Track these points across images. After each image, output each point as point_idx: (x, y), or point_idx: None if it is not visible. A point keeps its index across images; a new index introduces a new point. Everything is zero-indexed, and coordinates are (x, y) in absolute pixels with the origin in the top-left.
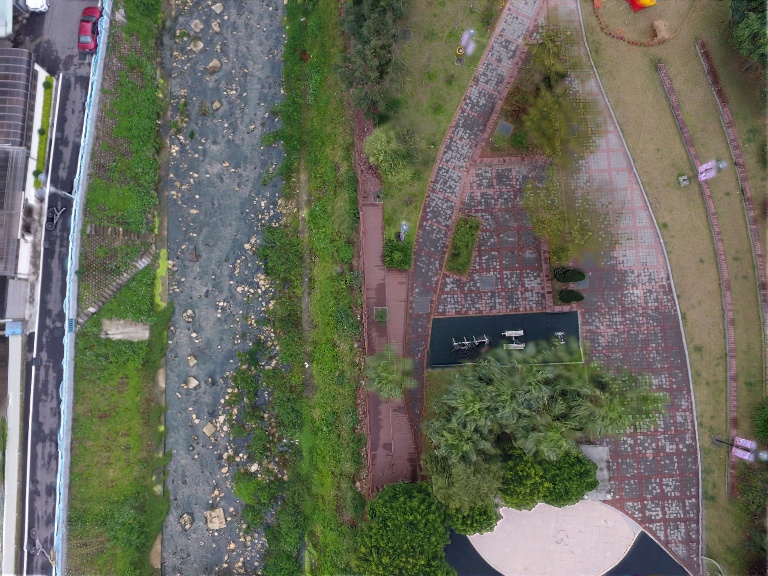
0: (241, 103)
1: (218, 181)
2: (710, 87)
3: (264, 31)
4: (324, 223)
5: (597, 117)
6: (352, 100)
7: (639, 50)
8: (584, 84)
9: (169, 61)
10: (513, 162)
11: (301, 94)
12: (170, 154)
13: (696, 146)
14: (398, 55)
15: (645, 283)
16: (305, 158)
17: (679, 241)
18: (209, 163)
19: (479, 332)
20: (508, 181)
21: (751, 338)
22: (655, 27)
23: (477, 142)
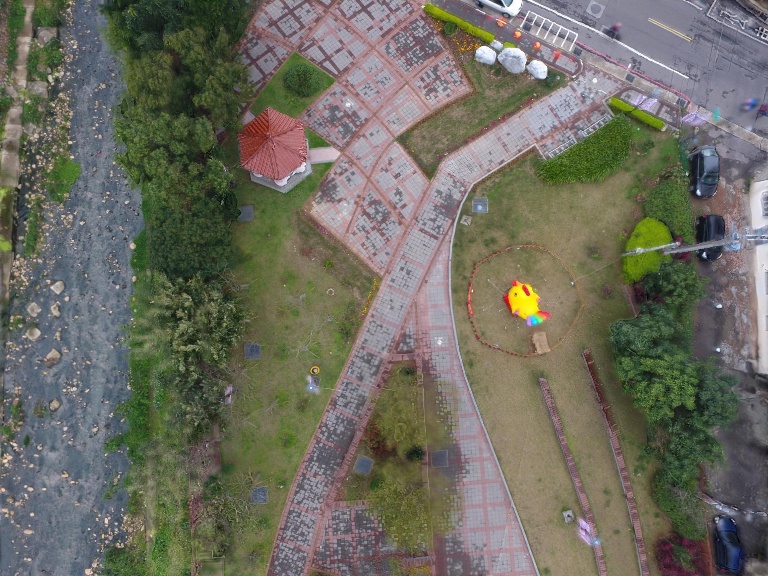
0: (83, 401)
1: (56, 495)
2: (599, 404)
3: (110, 314)
4: (164, 568)
5: (471, 442)
6: (190, 434)
7: (519, 361)
8: (457, 403)
9: (2, 352)
10: (374, 503)
11: (149, 393)
12: (2, 464)
13: (582, 476)
14: (243, 379)
15: None
16: (152, 470)
17: None
18: (46, 473)
19: None
20: (369, 523)
21: None
22: (535, 341)
23: (334, 478)
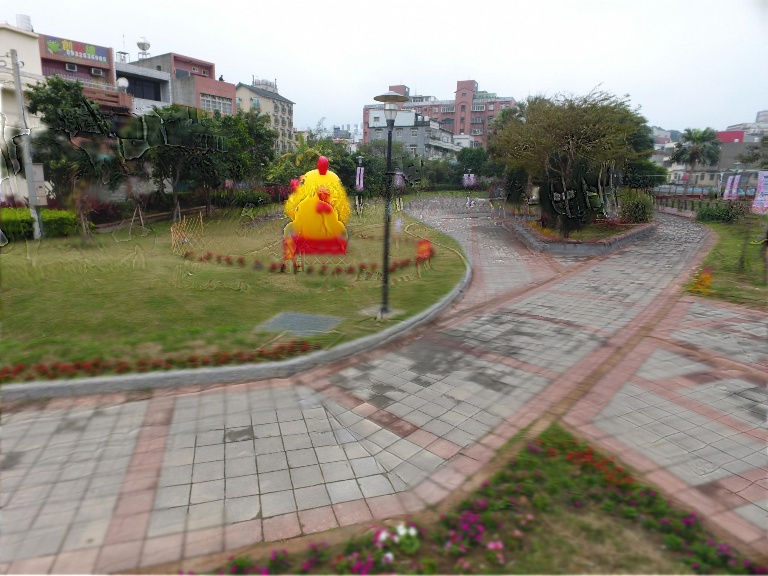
0: None
1: None
2: None
3: None
4: None
5: None
6: None
7: None
8: None
9: None
10: None
11: None
12: None
13: None
14: None
15: None
16: None
17: None
18: None
19: None
20: None
21: None
22: None
23: None
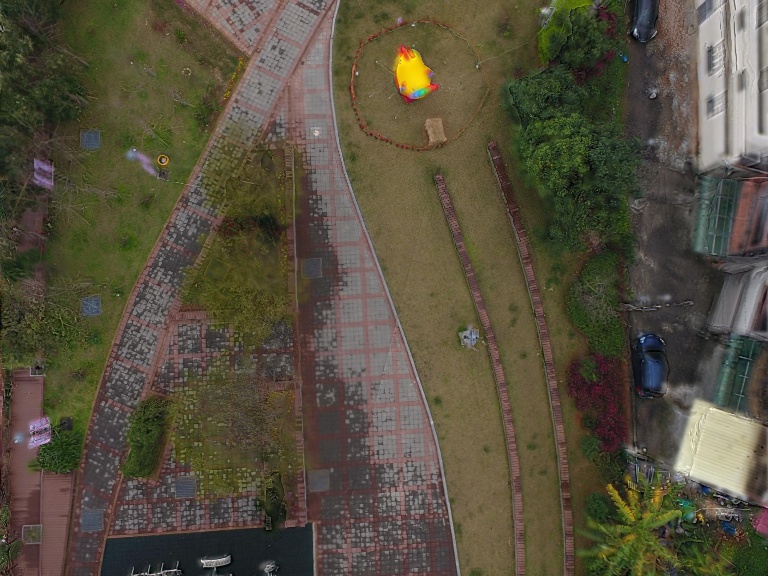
0: None
1: None
2: (505, 207)
3: None
4: None
5: (350, 249)
6: None
7: (411, 156)
8: (334, 204)
9: None
10: (228, 316)
11: None
12: None
13: (483, 290)
14: (76, 167)
15: (407, 482)
16: None
17: (456, 423)
18: None
19: (171, 557)
20: (223, 341)
21: (549, 559)
22: (427, 127)
23: (182, 287)
